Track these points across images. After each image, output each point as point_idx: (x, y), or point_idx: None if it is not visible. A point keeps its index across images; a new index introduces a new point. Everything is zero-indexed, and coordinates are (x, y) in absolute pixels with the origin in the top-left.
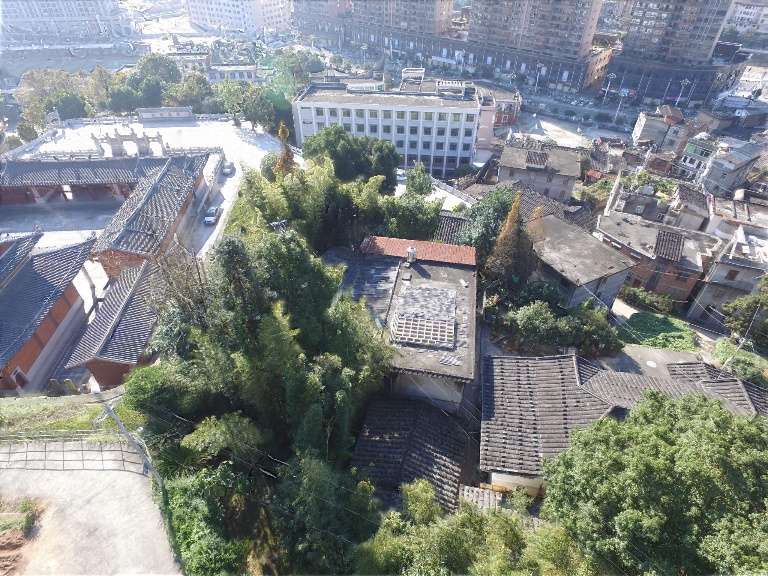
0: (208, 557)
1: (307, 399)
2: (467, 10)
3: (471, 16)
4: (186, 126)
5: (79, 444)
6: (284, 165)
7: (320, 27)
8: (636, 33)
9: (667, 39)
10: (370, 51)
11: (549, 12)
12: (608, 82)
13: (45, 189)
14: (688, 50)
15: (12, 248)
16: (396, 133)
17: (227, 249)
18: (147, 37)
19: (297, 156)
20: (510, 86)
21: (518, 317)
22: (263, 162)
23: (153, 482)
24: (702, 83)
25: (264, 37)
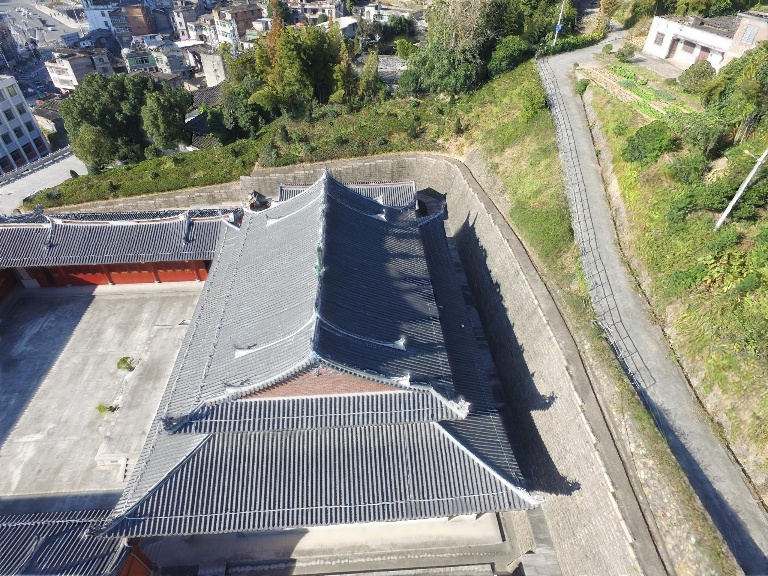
0: None
1: None
2: None
3: None
4: None
5: None
6: None
7: None
8: None
9: None
10: None
11: None
12: None
13: None
14: None
15: None
16: None
17: None
18: None
19: None
20: None
21: None
22: (157, 102)
23: None
24: None
25: None
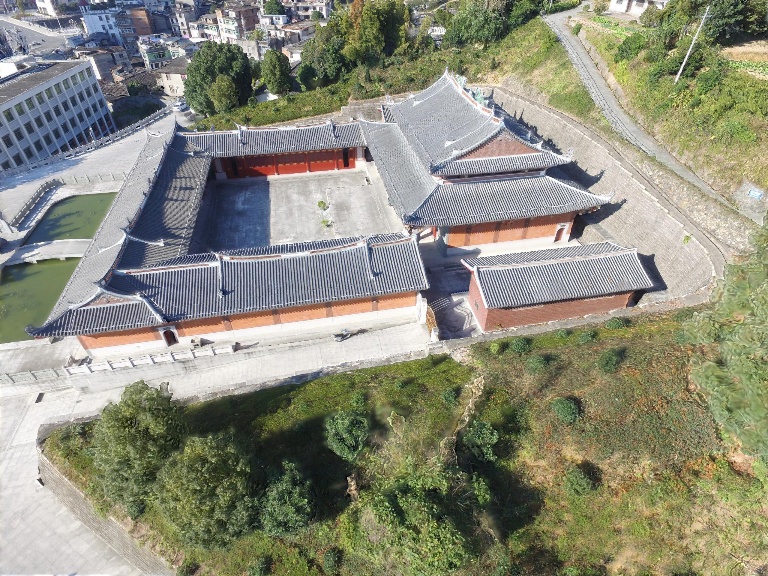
0: None
1: None
2: None
3: None
4: None
5: None
6: None
7: None
8: None
9: None
10: None
11: None
12: None
13: None
14: None
15: None
16: (56, 117)
17: None
18: None
19: (88, 154)
20: None
21: None
22: (276, 55)
23: None
24: None
25: None
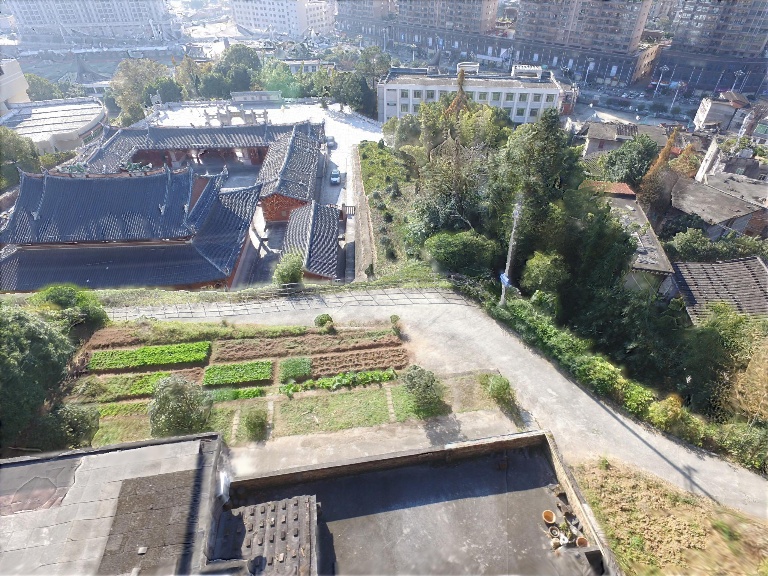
0: (571, 343)
1: (607, 243)
2: (509, 11)
3: (519, 14)
4: (277, 108)
5: (397, 290)
6: (457, 107)
7: (364, 29)
8: (686, 27)
9: (718, 33)
10: (419, 49)
11: (599, 8)
12: (658, 75)
13: (181, 154)
14: (740, 43)
15: (209, 183)
16: None
17: (554, 114)
18: (196, 41)
19: None
20: (564, 78)
21: (676, 241)
22: (401, 120)
23: (489, 305)
24: (754, 75)
25: (311, 38)
